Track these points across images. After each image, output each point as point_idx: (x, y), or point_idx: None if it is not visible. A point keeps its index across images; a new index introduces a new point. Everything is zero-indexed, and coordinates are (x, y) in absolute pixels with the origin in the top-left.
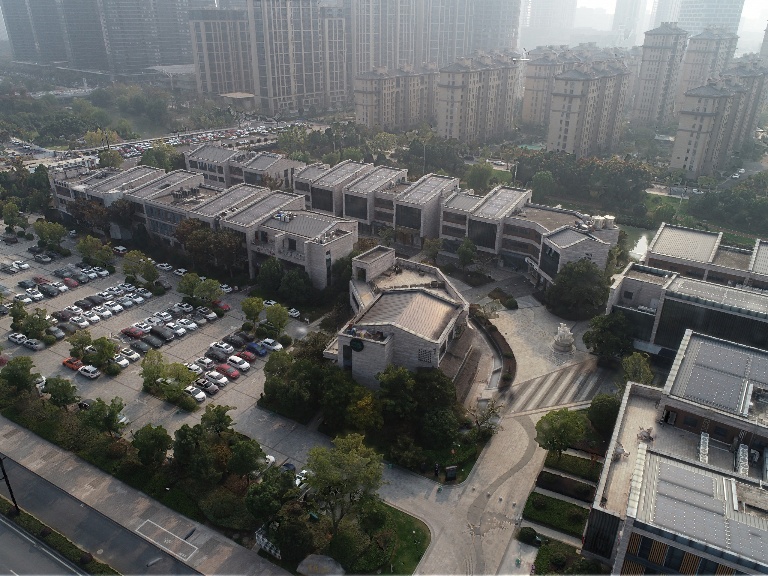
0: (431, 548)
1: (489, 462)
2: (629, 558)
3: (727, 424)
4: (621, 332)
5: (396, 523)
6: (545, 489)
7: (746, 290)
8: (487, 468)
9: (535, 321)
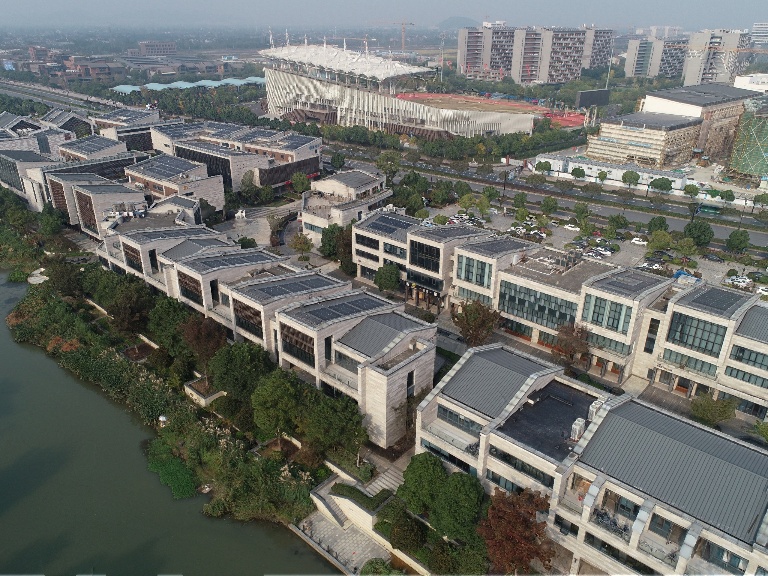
0: None
1: None
2: None
3: None
4: None
5: None
6: None
7: (144, 174)
8: None
9: None
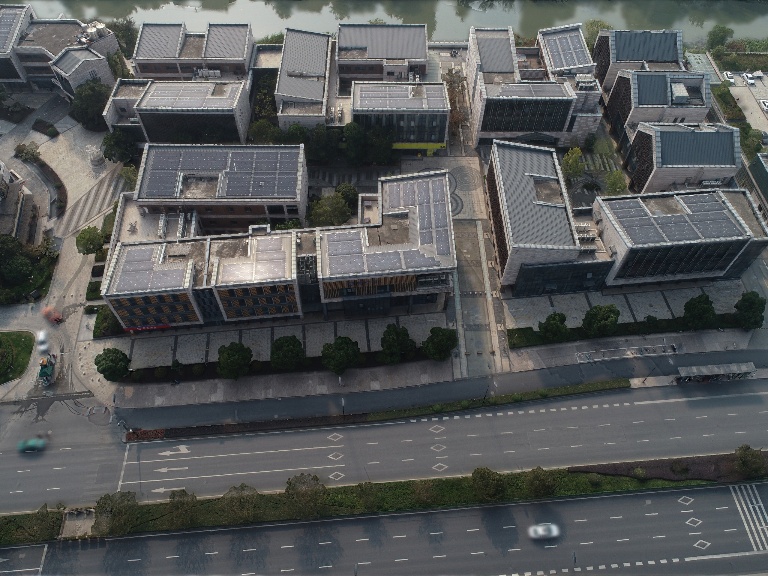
0: (36, 343)
1: (60, 275)
2: (117, 309)
3: (171, 205)
4: (123, 145)
5: (10, 340)
6: (97, 277)
7: (196, 81)
8: (60, 280)
9: (75, 143)
